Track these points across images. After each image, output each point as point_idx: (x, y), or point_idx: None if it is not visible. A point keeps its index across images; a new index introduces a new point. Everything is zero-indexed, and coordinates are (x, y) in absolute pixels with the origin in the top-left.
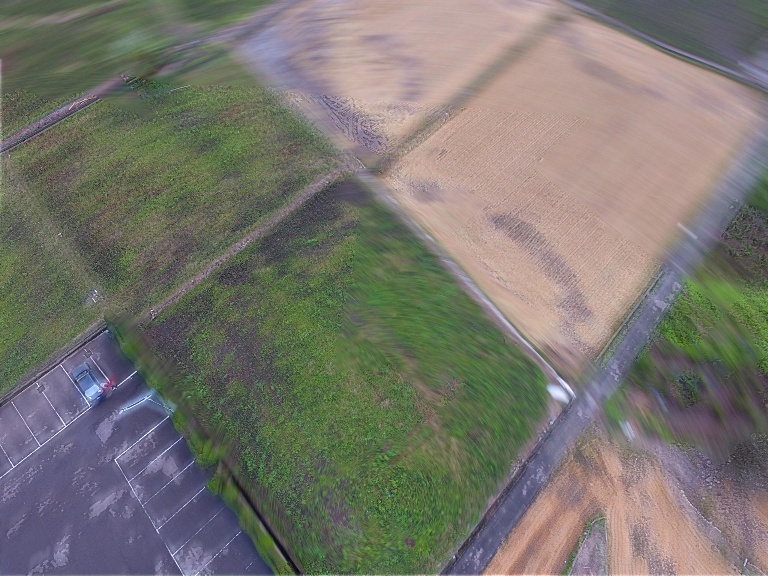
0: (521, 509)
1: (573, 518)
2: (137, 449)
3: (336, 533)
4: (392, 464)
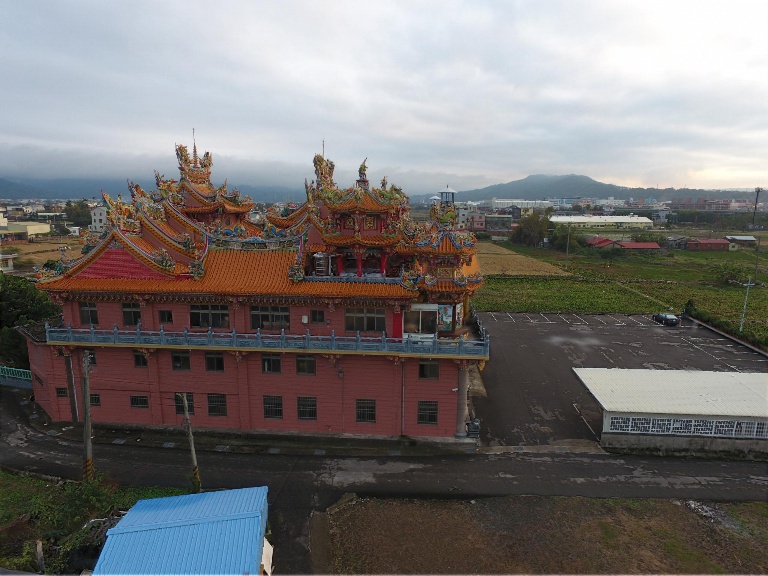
0: None
1: None
2: None
3: None
4: None
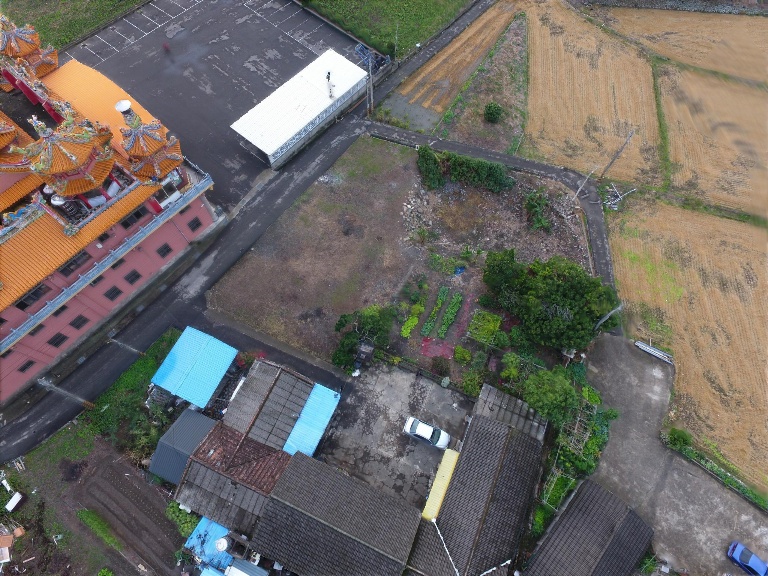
0: (478, 13)
1: (508, 15)
2: (256, 0)
3: (376, 25)
4: (404, 0)
